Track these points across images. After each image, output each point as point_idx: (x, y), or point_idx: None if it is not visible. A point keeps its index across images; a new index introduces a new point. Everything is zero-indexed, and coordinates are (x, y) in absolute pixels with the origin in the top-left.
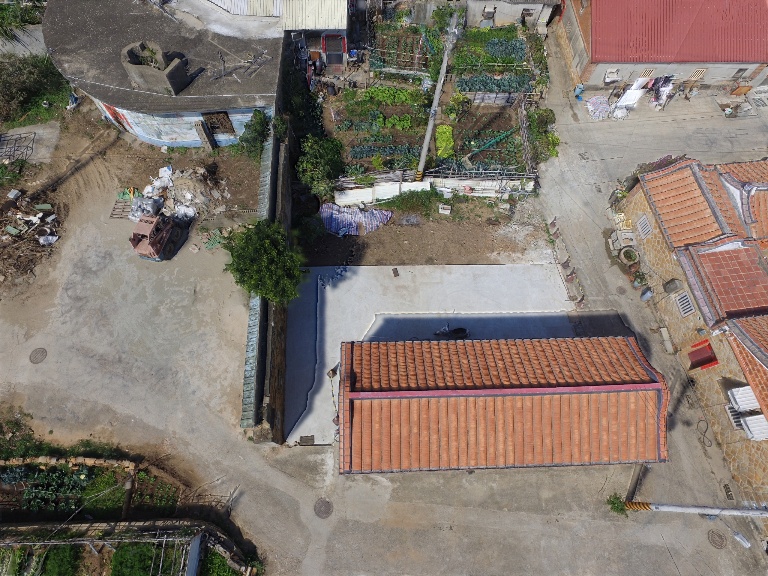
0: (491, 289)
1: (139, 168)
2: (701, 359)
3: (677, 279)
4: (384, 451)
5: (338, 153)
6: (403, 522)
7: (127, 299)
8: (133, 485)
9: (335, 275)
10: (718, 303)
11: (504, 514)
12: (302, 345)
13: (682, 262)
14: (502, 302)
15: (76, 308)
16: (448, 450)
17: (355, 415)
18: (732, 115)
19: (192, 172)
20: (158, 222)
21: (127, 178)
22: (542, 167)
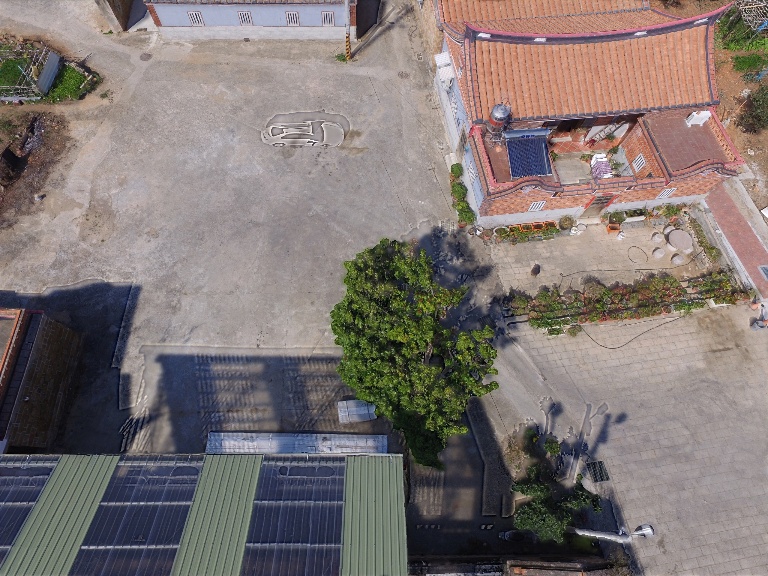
0: None
1: None
2: None
3: None
4: None
5: None
6: (196, 61)
7: None
8: None
9: None
10: None
11: (264, 59)
12: None
13: None
14: None
15: None
16: None
17: None
18: None
19: None
20: None
21: None
22: None
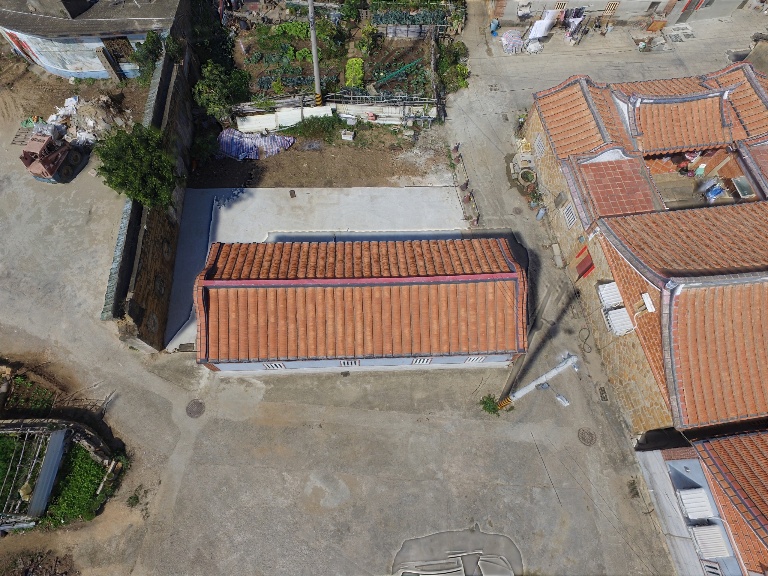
0: (387, 209)
1: (45, 98)
2: (585, 269)
3: (563, 191)
4: (241, 340)
5: (246, 84)
6: (273, 420)
7: (21, 219)
8: (9, 389)
9: (231, 196)
10: (592, 206)
11: (375, 413)
12: (191, 260)
13: (564, 172)
14: (397, 221)
15: None
16: (306, 340)
17: (211, 304)
18: (646, 49)
19: (96, 100)
20: (50, 141)
21: (32, 108)
22: (451, 97)
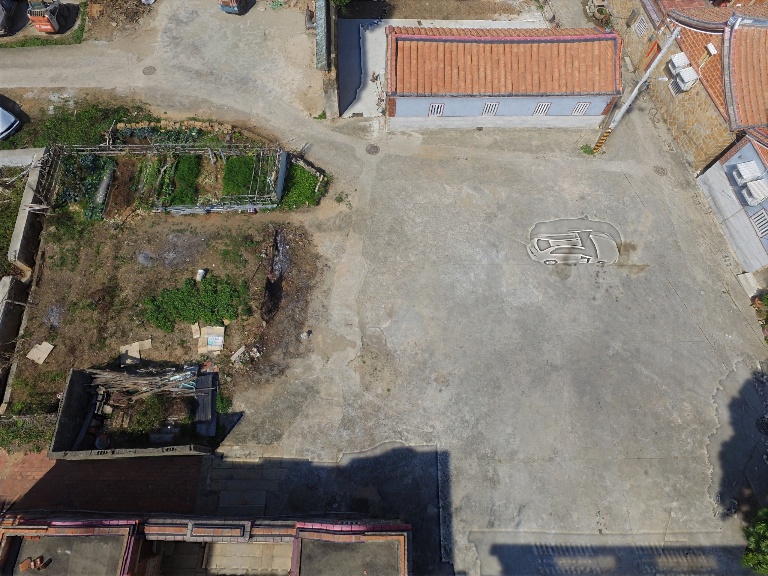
0: None
1: None
2: None
3: (635, 8)
4: (420, 80)
5: None
6: (431, 155)
7: (213, 38)
8: (231, 140)
9: (373, 24)
10: (663, 6)
11: (505, 152)
12: (350, 64)
13: None
14: None
15: (174, 43)
16: (465, 81)
17: (399, 53)
18: None
19: None
20: None
21: None
22: None
